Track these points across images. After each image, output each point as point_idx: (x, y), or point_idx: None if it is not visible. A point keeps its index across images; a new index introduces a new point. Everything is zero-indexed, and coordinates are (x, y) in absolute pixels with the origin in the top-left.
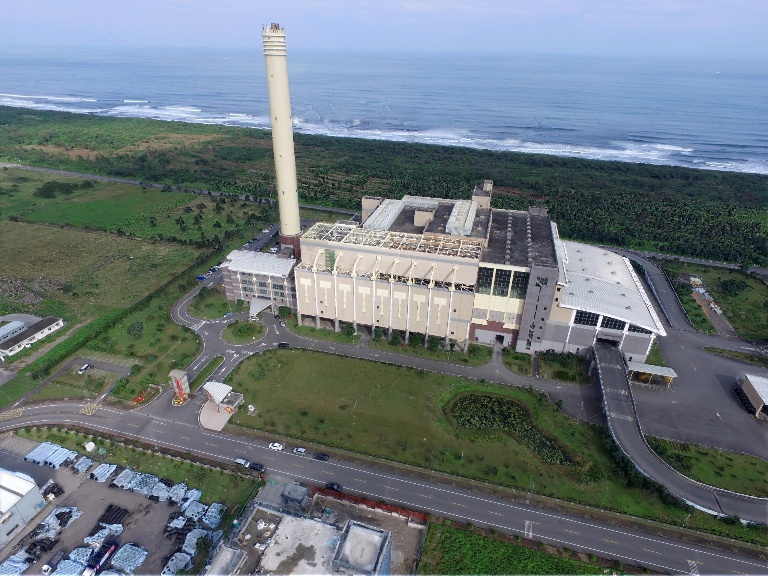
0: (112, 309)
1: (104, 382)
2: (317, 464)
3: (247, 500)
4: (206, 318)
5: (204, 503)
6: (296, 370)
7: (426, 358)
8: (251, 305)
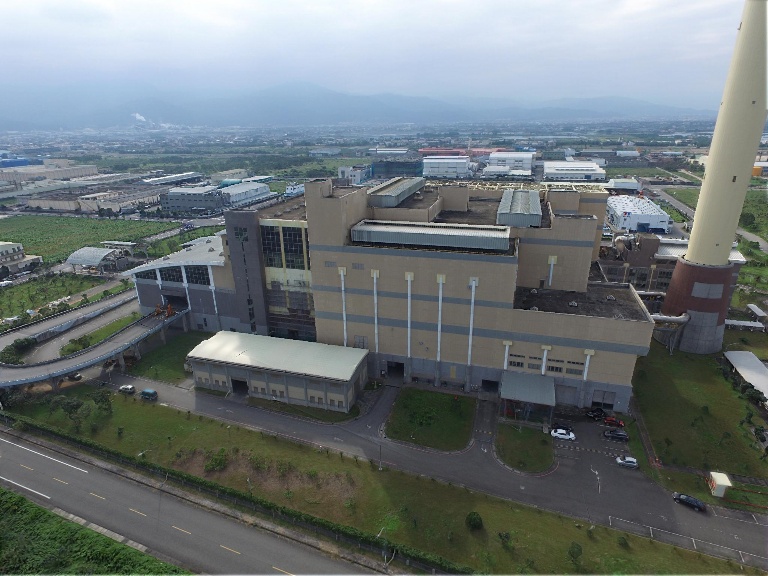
0: None
1: None
2: None
3: None
4: None
5: None
6: None
7: None
8: None
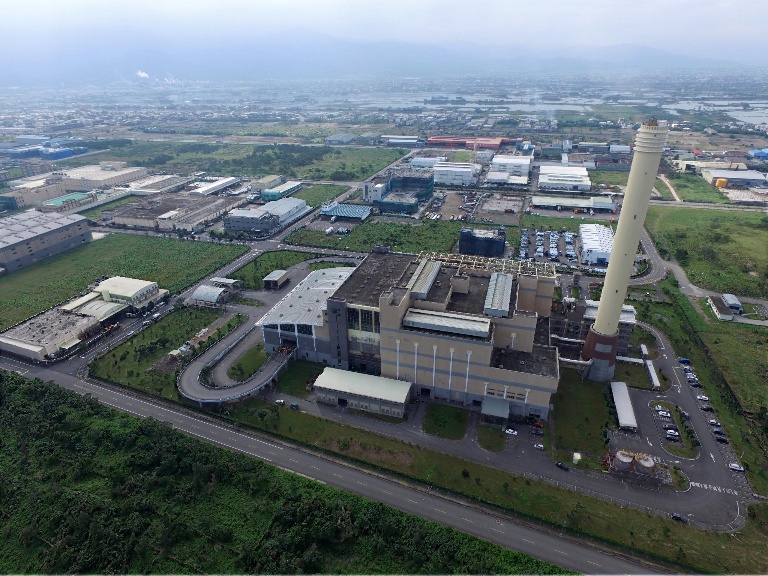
0: (708, 330)
1: None
2: None
3: None
4: None
5: None
6: None
7: None
8: None
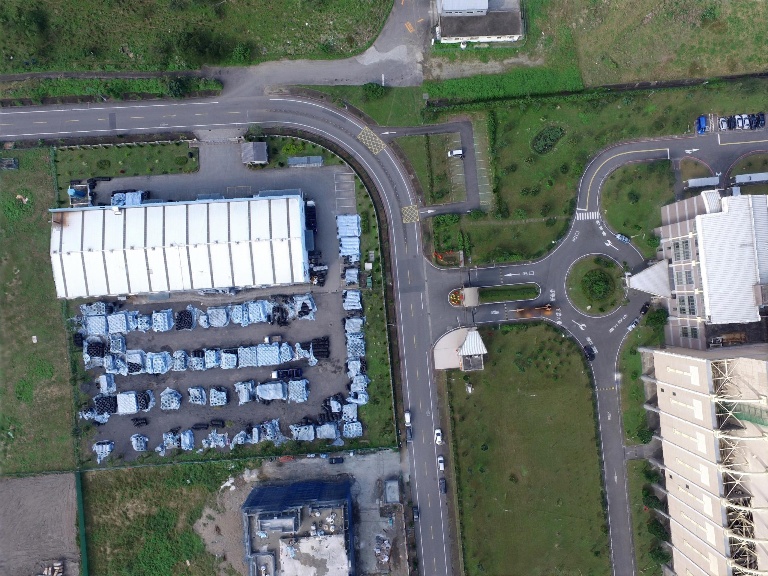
0: (573, 68)
1: (448, 194)
2: (434, 486)
3: (375, 448)
4: (605, 213)
5: (359, 413)
6: (551, 395)
7: (634, 541)
8: (647, 271)
